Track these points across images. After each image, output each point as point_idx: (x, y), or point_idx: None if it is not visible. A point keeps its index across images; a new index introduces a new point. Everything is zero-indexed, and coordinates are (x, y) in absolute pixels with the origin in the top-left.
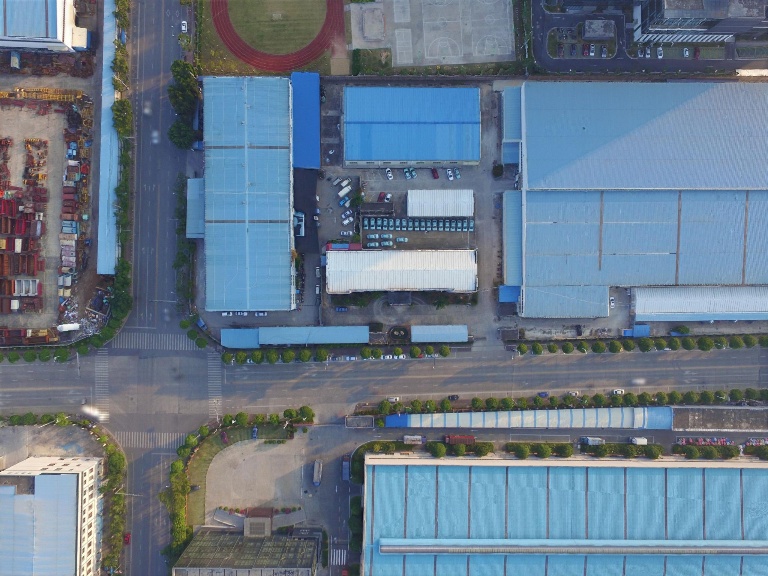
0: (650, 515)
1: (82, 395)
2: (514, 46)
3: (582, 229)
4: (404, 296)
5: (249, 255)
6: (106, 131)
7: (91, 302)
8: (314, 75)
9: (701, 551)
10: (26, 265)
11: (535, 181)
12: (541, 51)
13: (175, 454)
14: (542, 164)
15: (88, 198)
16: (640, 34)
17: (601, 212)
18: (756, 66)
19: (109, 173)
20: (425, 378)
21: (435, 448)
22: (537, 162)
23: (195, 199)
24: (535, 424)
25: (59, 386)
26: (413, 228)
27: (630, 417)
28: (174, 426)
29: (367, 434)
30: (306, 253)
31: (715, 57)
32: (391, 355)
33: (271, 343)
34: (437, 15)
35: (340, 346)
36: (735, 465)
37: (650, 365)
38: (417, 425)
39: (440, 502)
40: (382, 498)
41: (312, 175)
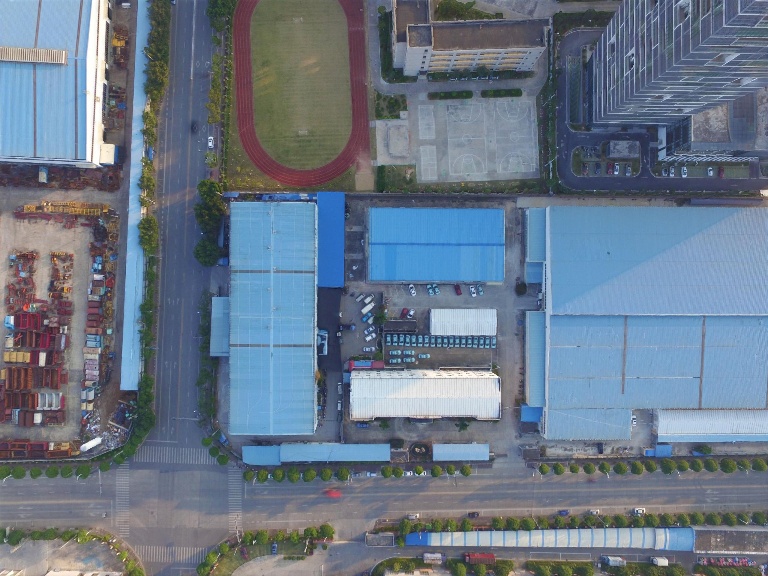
0: None
1: (103, 508)
2: (538, 163)
3: (606, 353)
4: None
5: (273, 379)
6: (132, 248)
7: (113, 415)
8: (339, 194)
9: None
10: (50, 379)
11: (559, 306)
12: (565, 169)
13: (194, 569)
14: (566, 289)
15: (112, 311)
16: (665, 156)
17: (625, 336)
18: None
19: (135, 295)
20: (445, 494)
21: (455, 570)
22: (561, 287)
23: (219, 318)
24: (556, 544)
25: (80, 499)
26: (435, 344)
27: (651, 538)
28: (194, 541)
29: (387, 551)
30: (328, 369)
31: (739, 176)
32: (412, 471)
33: (292, 460)
34: (462, 132)
35: (361, 463)
36: None
37: (671, 483)
38: (437, 544)
39: None
40: None
41: (336, 293)
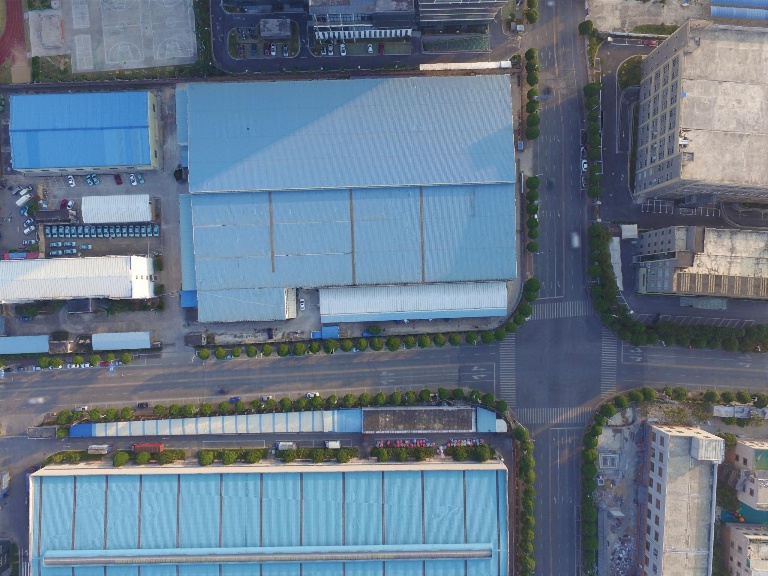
0: (327, 521)
1: None
2: (196, 48)
3: (252, 231)
4: (83, 304)
5: None
6: None
7: None
8: None
9: (377, 556)
10: None
11: (197, 184)
12: (222, 52)
13: None
14: (205, 167)
15: None
16: None
17: (270, 213)
18: (444, 60)
19: None
20: (114, 386)
21: None
22: (200, 165)
23: None
24: (223, 430)
25: None
26: (96, 235)
27: (320, 421)
28: None
29: (56, 444)
30: None
31: (401, 52)
32: None
33: None
34: (117, 20)
35: (23, 356)
36: (416, 467)
37: (345, 367)
38: (102, 434)
39: (118, 512)
40: (50, 509)
41: None
